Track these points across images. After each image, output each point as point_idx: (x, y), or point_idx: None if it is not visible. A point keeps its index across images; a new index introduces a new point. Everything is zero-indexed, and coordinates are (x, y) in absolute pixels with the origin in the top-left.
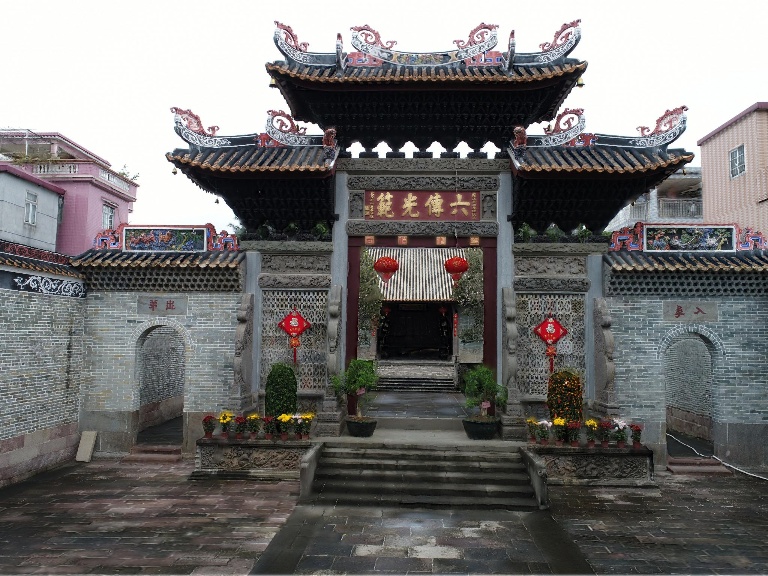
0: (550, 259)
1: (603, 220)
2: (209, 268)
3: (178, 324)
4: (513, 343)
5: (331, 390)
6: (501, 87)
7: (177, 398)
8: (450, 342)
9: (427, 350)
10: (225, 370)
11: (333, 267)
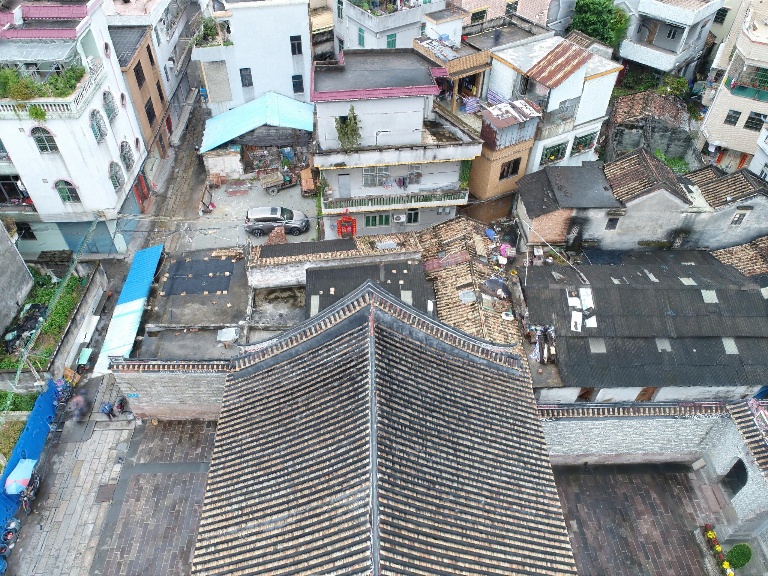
0: None
1: None
2: None
3: (750, 473)
4: None
5: None
6: None
7: None
8: None
9: None
10: None
11: None
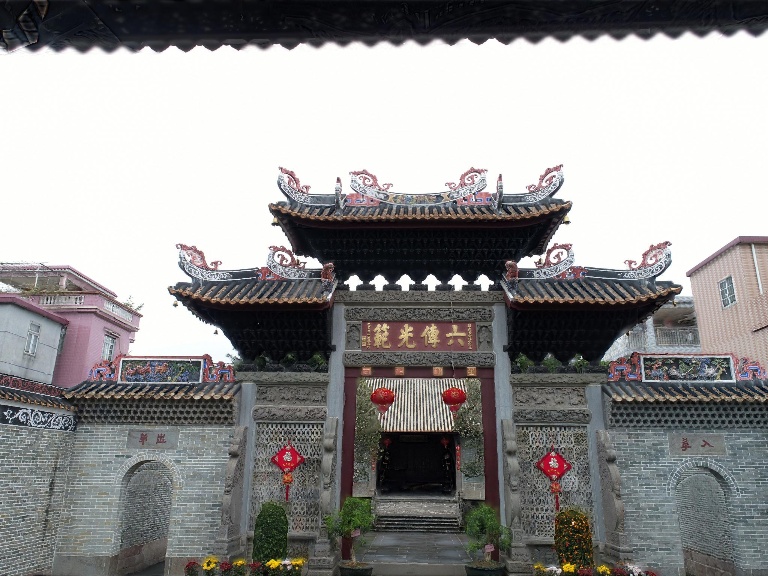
0: (549, 390)
1: (599, 350)
2: (203, 400)
3: (167, 459)
4: (515, 479)
5: (324, 532)
6: (491, 224)
7: (161, 540)
8: (453, 476)
9: (430, 485)
10: (213, 509)
11: (329, 398)
